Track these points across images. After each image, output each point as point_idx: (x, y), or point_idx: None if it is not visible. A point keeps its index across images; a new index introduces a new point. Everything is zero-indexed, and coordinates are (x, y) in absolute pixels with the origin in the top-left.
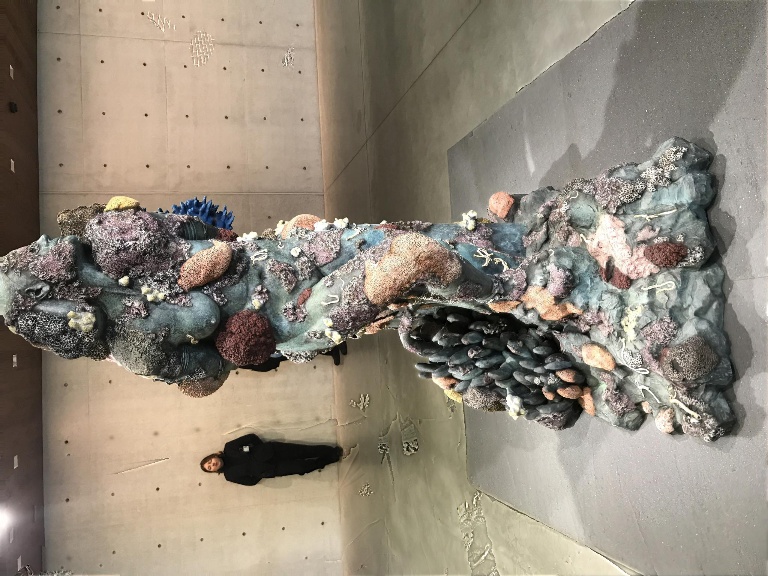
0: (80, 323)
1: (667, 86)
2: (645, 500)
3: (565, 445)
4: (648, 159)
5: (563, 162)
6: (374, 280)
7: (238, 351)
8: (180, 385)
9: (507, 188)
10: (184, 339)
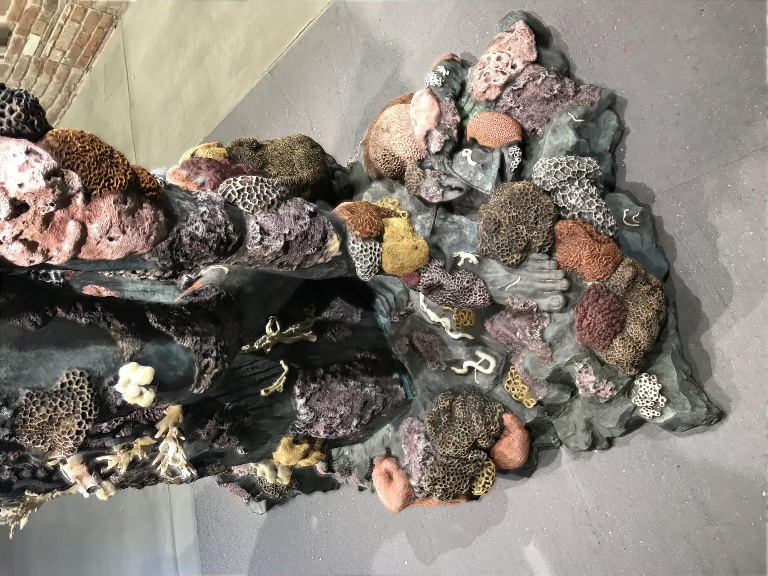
0: None
1: (302, 575)
2: (285, 134)
3: (389, 83)
4: (313, 502)
5: (443, 540)
6: None
7: None
8: None
9: (638, 532)
10: None
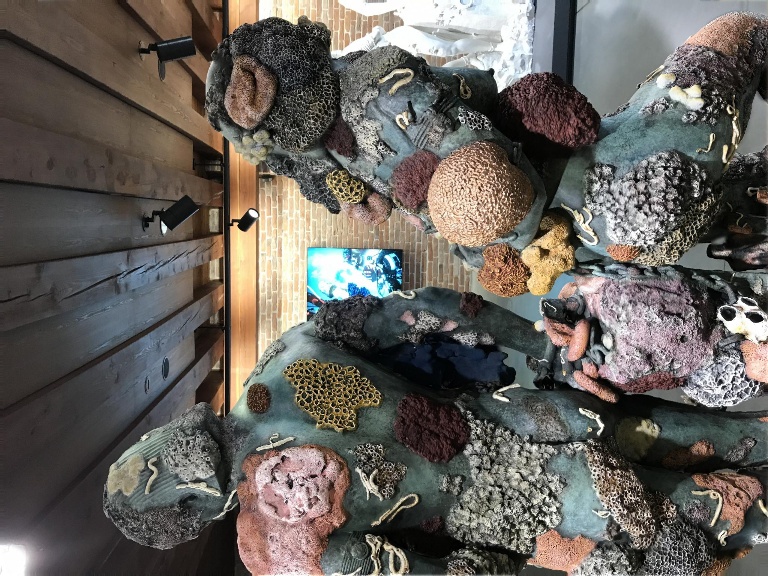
0: (312, 22)
1: None
2: None
3: None
4: None
5: None
6: (698, 34)
7: (538, 79)
8: (448, 162)
9: None
10: (449, 84)
